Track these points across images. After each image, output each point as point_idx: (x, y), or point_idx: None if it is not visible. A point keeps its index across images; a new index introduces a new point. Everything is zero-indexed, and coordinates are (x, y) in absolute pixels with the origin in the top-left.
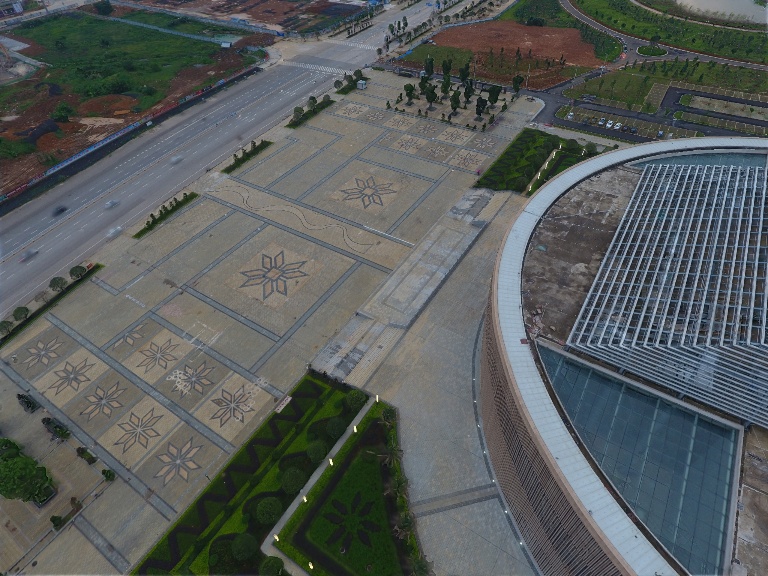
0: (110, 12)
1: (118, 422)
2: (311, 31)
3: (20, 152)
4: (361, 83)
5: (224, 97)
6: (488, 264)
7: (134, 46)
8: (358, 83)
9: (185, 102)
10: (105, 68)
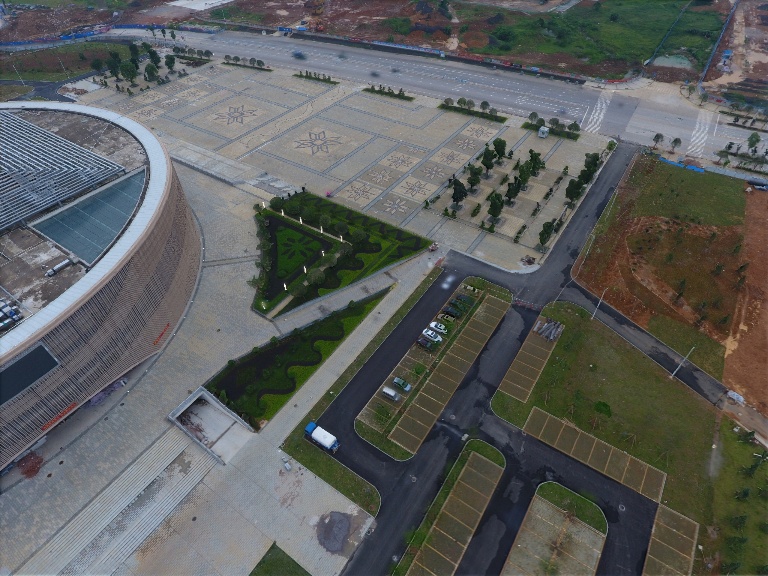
0: (701, 5)
1: (158, 92)
2: (731, 98)
3: (400, 31)
4: (540, 128)
5: (504, 75)
6: (184, 181)
7: (619, 29)
8: (541, 127)
9: (489, 63)
10: (557, 28)
